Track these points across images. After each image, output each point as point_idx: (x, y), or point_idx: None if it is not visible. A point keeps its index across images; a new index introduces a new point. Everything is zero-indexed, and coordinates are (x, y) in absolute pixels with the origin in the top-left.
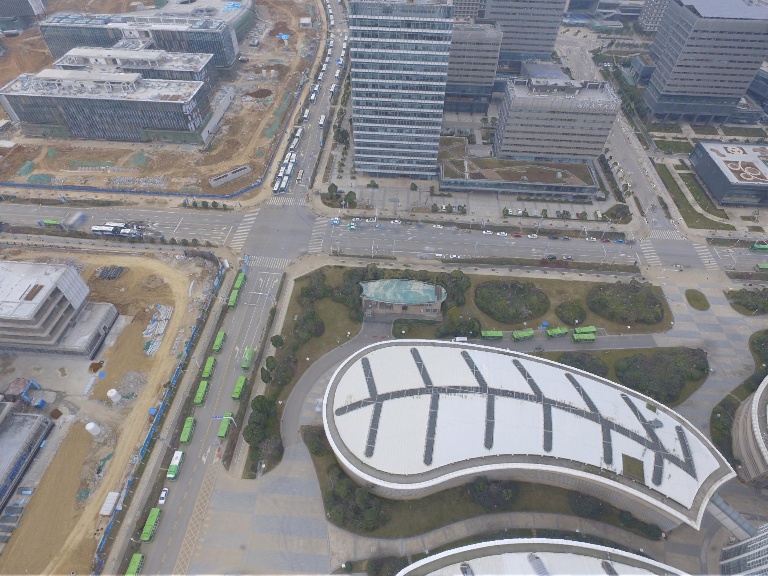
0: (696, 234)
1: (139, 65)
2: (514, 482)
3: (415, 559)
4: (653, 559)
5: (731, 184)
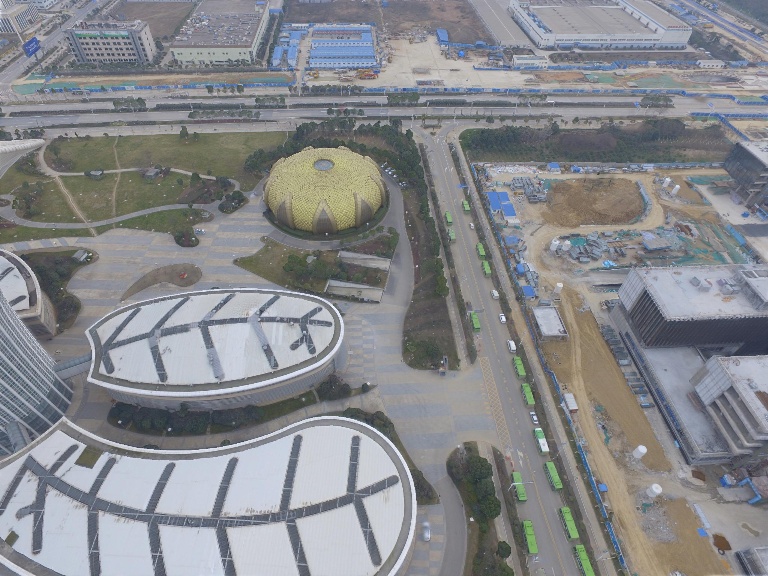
0: None
1: None
2: None
3: (313, 400)
4: (112, 424)
5: None
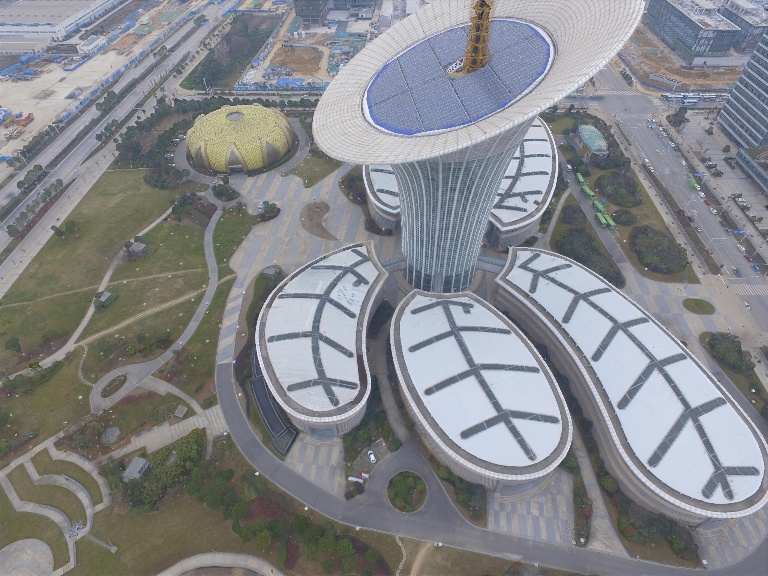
0: None
1: (736, 9)
2: None
3: None
4: None
5: None
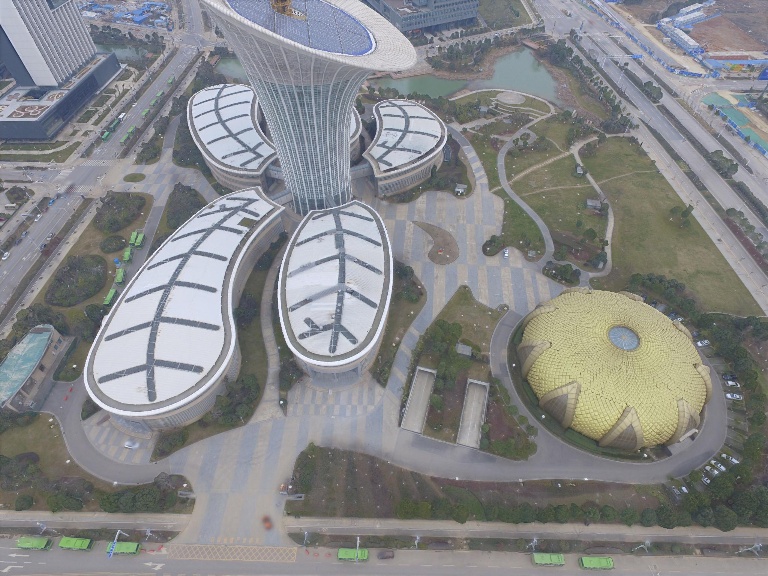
0: (72, 161)
1: None
2: (242, 298)
3: None
4: None
5: (38, 121)
